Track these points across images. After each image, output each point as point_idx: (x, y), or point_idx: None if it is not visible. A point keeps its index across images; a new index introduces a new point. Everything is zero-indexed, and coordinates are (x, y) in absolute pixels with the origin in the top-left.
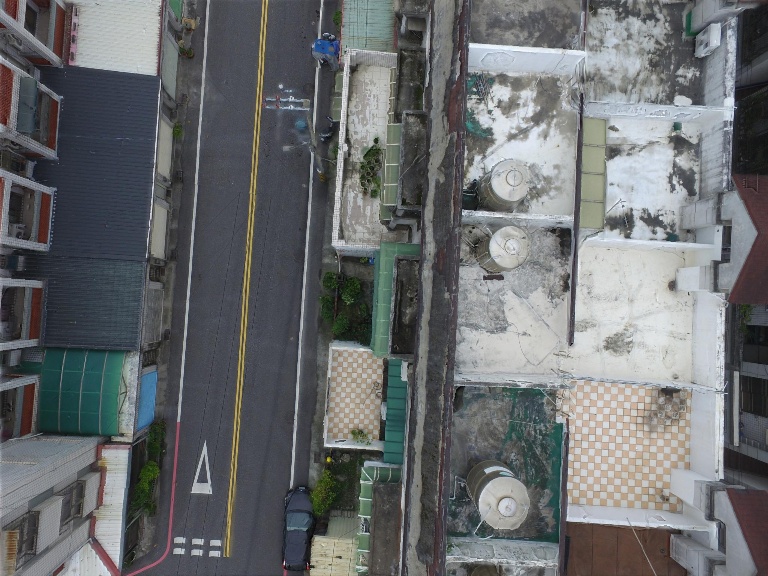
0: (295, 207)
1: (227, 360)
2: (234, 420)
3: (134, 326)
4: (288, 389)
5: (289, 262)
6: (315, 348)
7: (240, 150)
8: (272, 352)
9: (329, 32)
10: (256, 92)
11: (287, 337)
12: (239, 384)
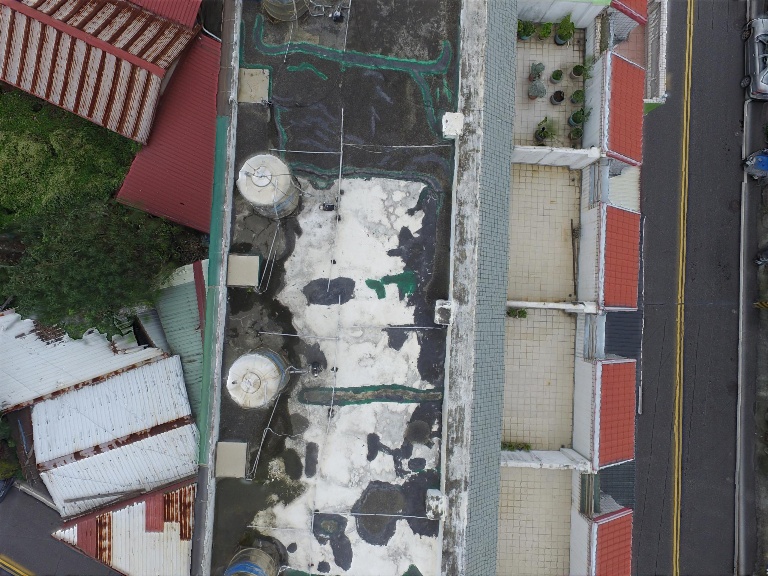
0: (725, 335)
1: (660, 503)
2: (673, 570)
3: (630, 490)
4: (726, 534)
5: (722, 395)
6: (753, 489)
7: (664, 273)
8: (708, 494)
9: (754, 143)
10: (680, 210)
11: (722, 477)
12: (676, 530)
